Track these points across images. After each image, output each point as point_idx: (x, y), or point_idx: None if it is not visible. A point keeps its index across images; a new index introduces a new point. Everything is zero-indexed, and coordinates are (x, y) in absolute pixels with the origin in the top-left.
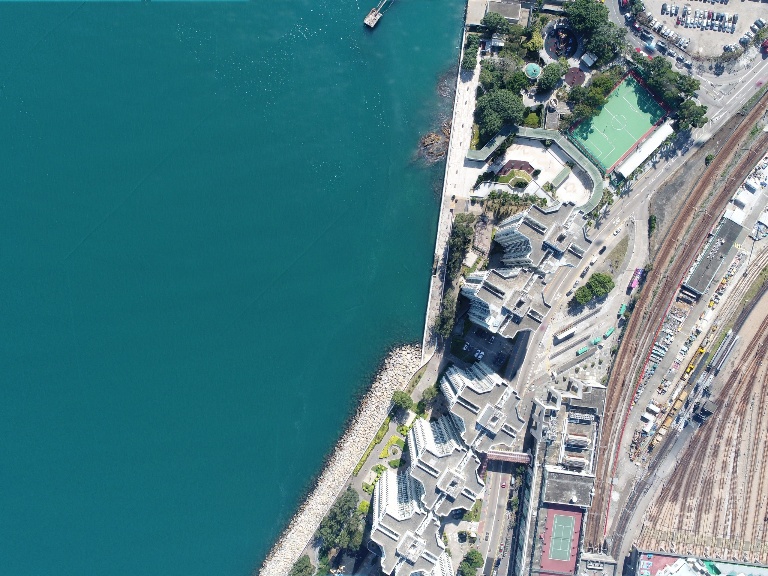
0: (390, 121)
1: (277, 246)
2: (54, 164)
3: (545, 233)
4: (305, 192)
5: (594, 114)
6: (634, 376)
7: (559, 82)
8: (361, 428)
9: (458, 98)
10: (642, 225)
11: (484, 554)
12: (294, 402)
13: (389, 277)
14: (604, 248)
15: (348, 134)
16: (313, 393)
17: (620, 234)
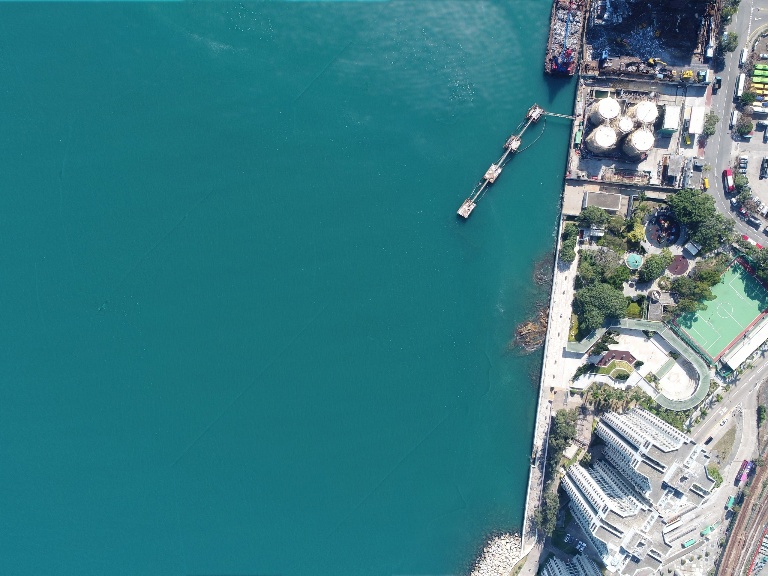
0: (485, 310)
1: (378, 450)
2: (158, 374)
3: (665, 472)
4: (405, 397)
5: (701, 309)
6: (743, 569)
7: None
8: None
9: (555, 288)
10: (750, 415)
11: None
12: None
13: (487, 466)
14: (710, 439)
15: (448, 340)
16: None
17: (727, 424)
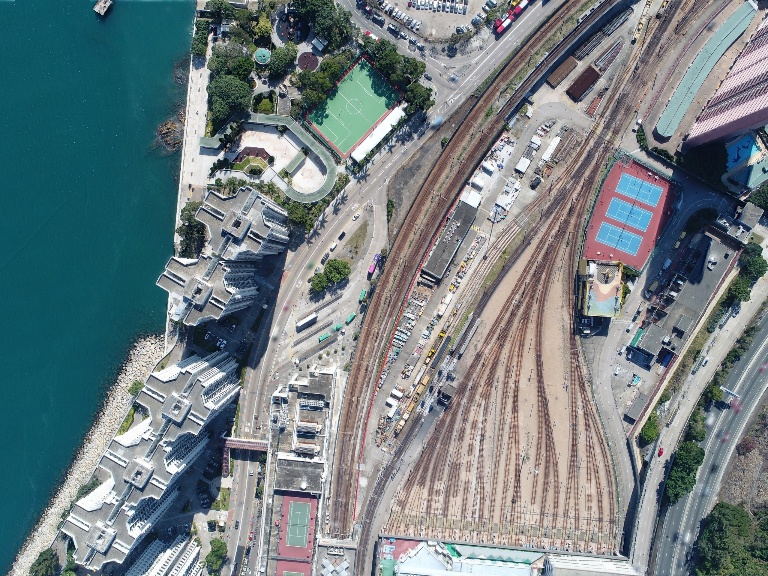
0: (126, 110)
1: None
2: None
3: (224, 219)
4: (24, 183)
5: (320, 99)
6: (377, 361)
7: (292, 67)
8: (107, 420)
9: (192, 85)
10: (381, 210)
11: (235, 543)
12: (40, 395)
13: (131, 268)
14: (342, 234)
15: (64, 124)
16: (60, 386)
17: (359, 219)
